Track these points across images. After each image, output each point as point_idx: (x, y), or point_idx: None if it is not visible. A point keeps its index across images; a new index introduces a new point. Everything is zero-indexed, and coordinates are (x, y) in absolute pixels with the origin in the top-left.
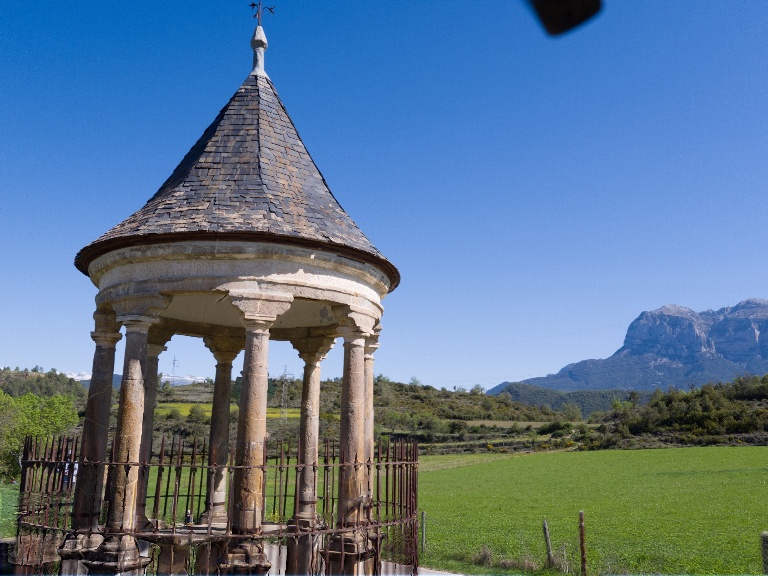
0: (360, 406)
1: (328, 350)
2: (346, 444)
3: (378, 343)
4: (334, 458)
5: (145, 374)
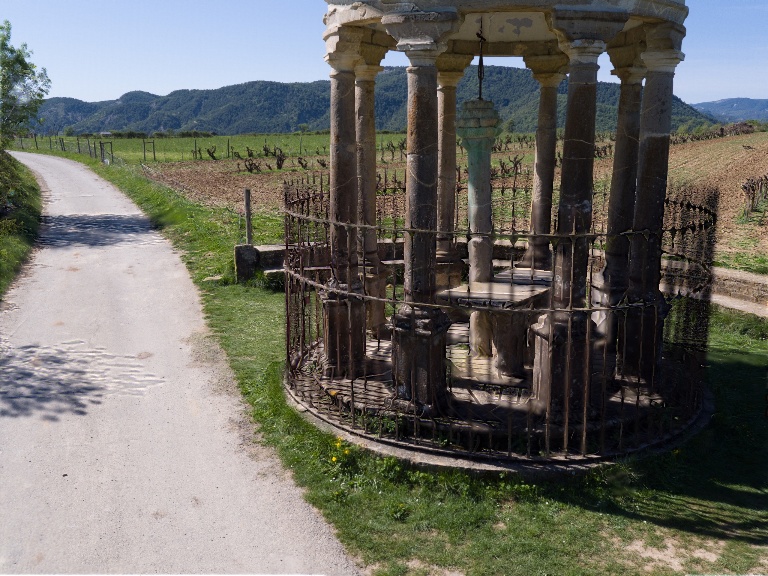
0: (359, 145)
1: (397, 37)
2: (371, 180)
3: None
4: None
5: None
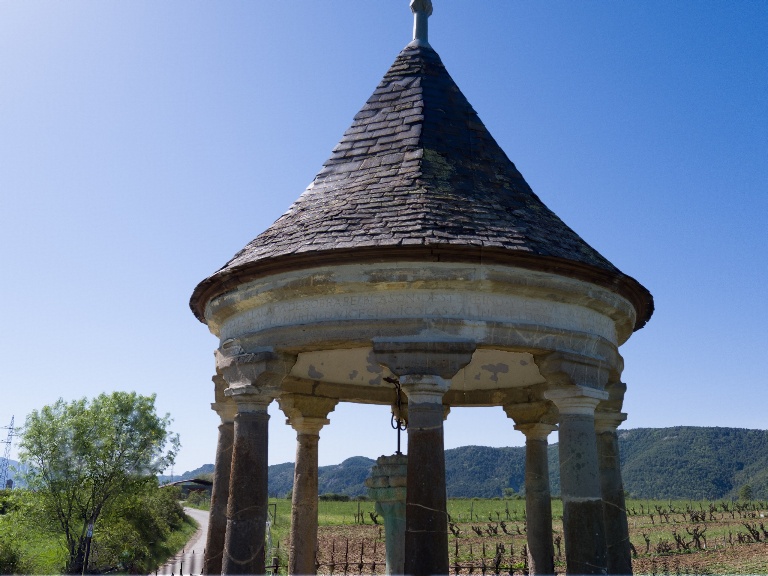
0: None
1: None
2: None
3: None
4: None
5: (527, 484)
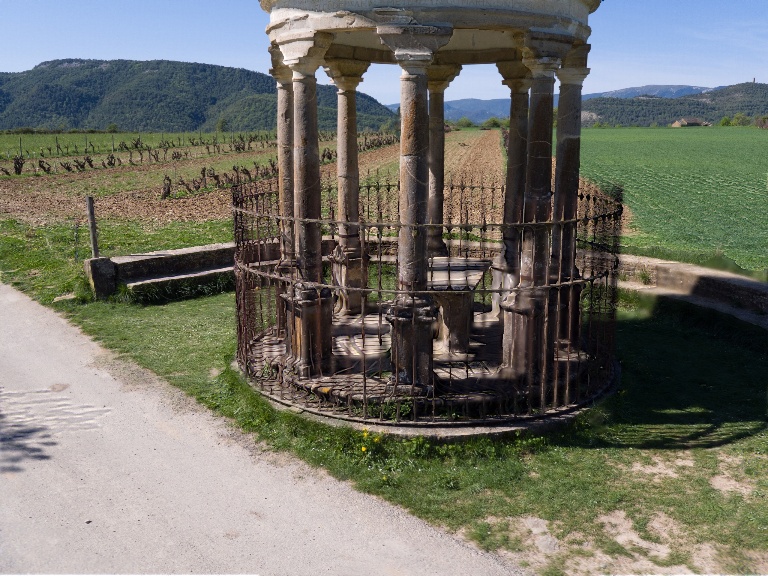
0: None
1: (392, 47)
2: None
3: (285, 59)
4: (399, 228)
5: None
